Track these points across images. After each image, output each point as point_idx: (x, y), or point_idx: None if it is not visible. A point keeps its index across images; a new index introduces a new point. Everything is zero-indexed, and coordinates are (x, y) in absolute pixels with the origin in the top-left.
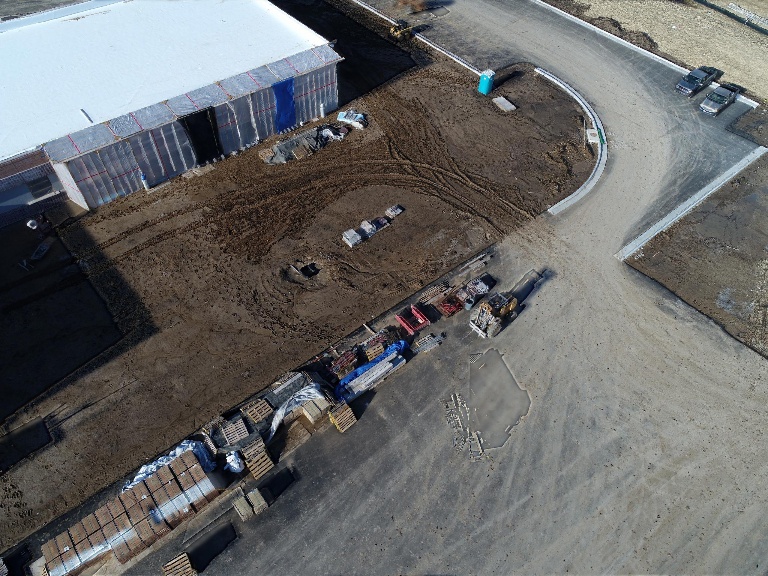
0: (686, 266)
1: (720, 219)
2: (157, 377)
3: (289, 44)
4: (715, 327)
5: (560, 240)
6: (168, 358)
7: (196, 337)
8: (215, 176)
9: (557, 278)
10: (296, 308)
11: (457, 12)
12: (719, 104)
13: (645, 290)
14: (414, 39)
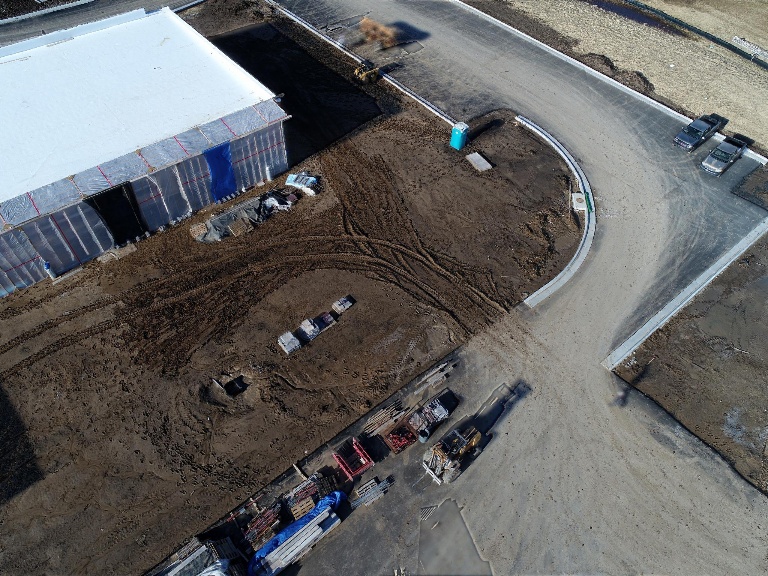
0: (687, 377)
1: (726, 311)
2: (29, 546)
3: (231, 97)
4: (722, 465)
5: (537, 342)
6: (47, 517)
7: (86, 485)
8: (136, 259)
9: (532, 395)
10: (214, 441)
11: (432, 48)
12: (724, 163)
13: (637, 412)
14: (381, 81)
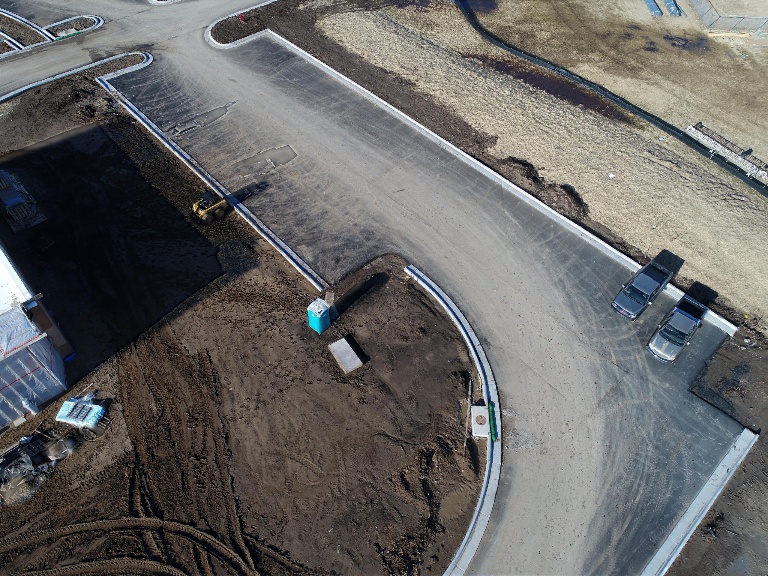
0: None
1: None
2: None
3: None
4: None
5: None
6: None
7: None
8: None
9: None
10: None
11: (307, 156)
12: (678, 346)
13: None
14: (232, 215)
